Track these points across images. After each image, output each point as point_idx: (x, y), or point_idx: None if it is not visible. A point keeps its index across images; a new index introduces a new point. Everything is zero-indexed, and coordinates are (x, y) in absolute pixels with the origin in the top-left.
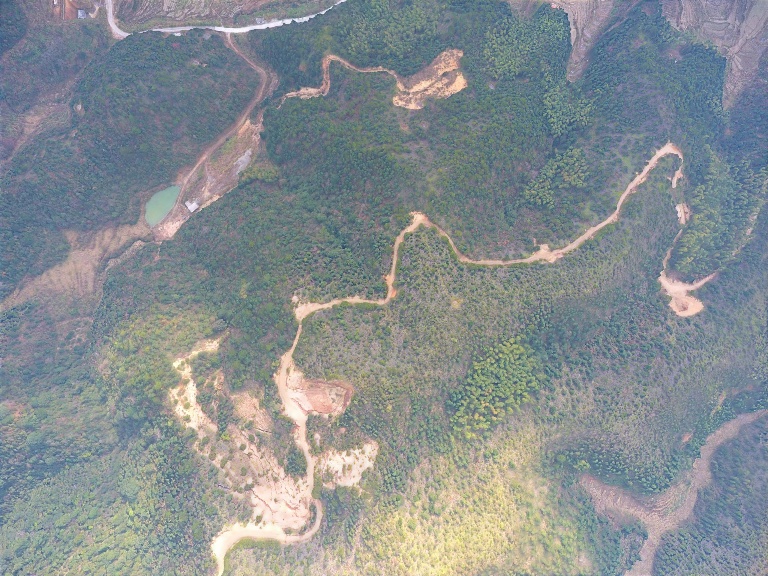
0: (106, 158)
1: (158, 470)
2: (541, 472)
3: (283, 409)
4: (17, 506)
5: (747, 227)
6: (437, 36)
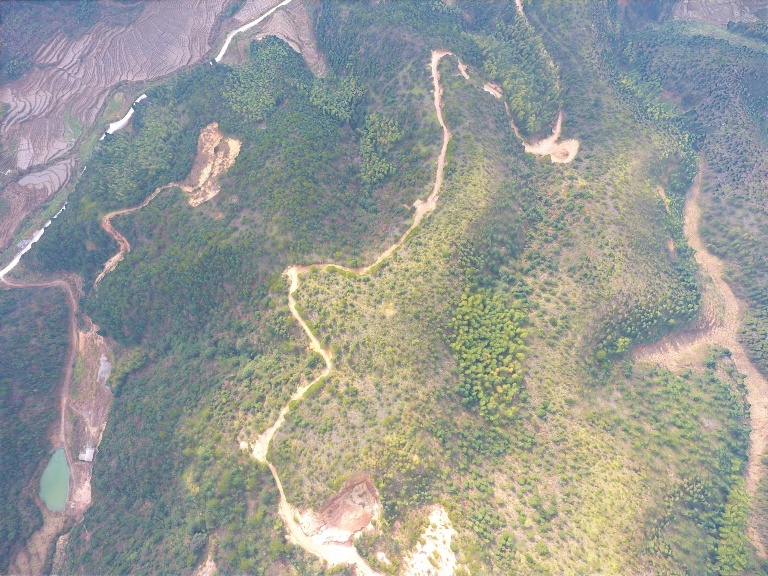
0: None
1: None
2: (598, 383)
3: (324, 563)
4: None
5: (547, 62)
6: (184, 129)
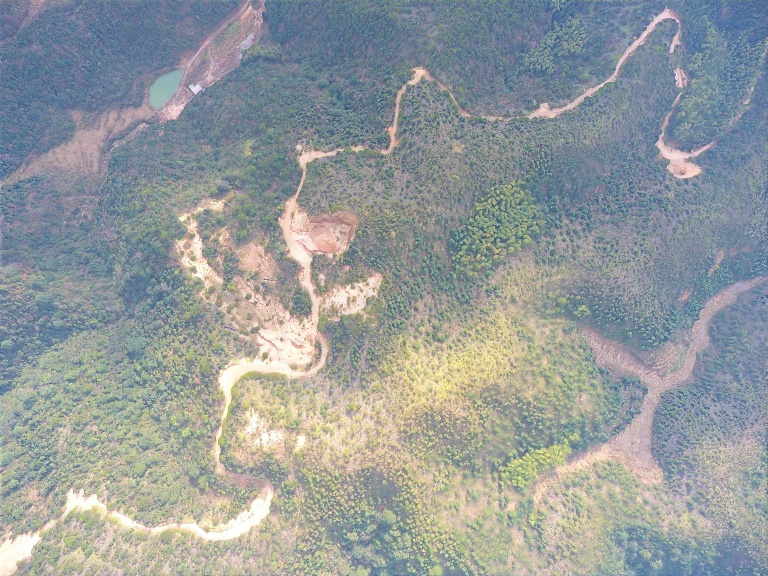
0: (110, 35)
1: (165, 324)
2: (542, 314)
3: (288, 251)
4: (26, 370)
5: (744, 97)
6: None
